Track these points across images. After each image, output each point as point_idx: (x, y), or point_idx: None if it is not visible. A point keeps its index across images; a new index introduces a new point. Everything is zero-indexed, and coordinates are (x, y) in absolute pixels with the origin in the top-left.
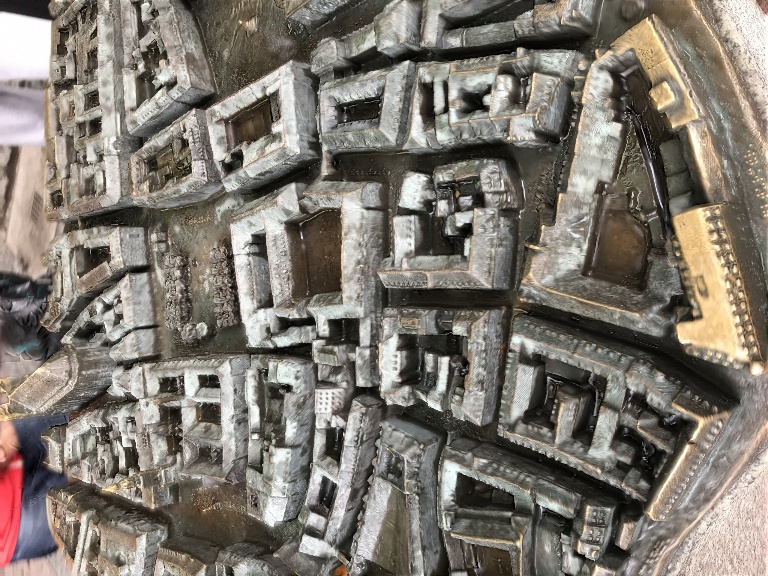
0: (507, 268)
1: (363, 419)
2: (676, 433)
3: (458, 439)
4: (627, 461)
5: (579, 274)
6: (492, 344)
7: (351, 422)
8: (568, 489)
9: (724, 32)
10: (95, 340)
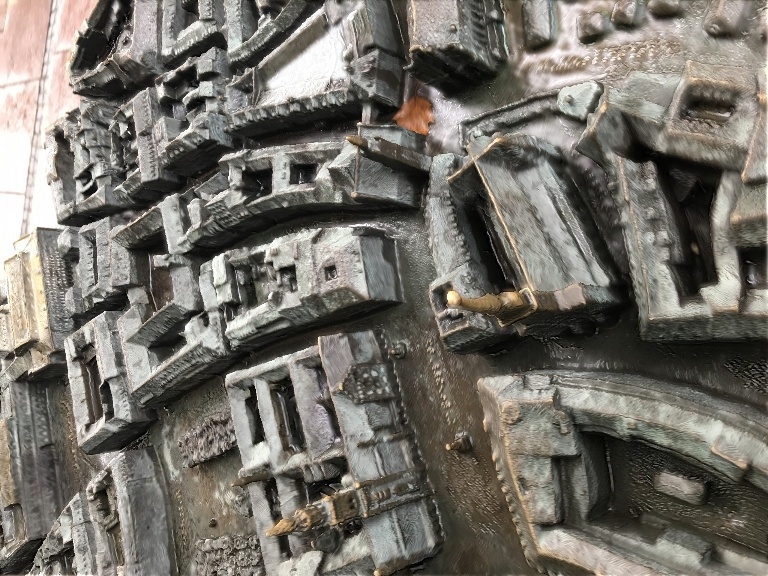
0: None
1: None
2: None
3: None
4: None
5: None
6: None
7: None
8: None
9: None
10: None
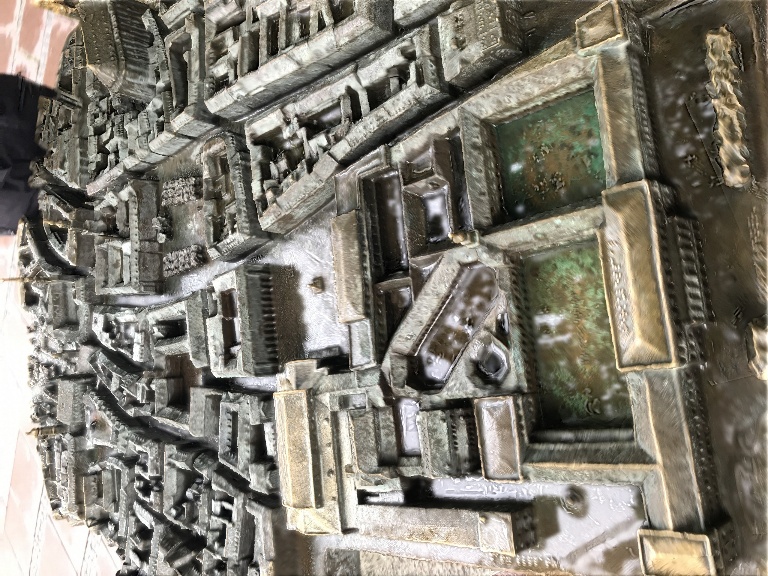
0: None
1: None
2: None
3: None
4: None
5: None
6: None
7: None
8: None
9: None
10: (151, 72)
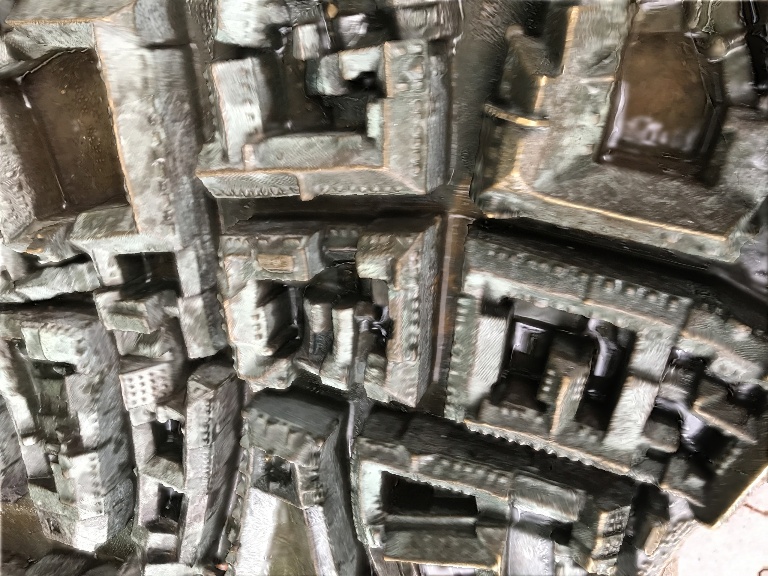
0: (441, 150)
1: (211, 407)
2: (755, 410)
3: (371, 417)
4: (668, 451)
5: (591, 161)
6: (425, 282)
7: (193, 416)
8: (564, 486)
9: None
10: None
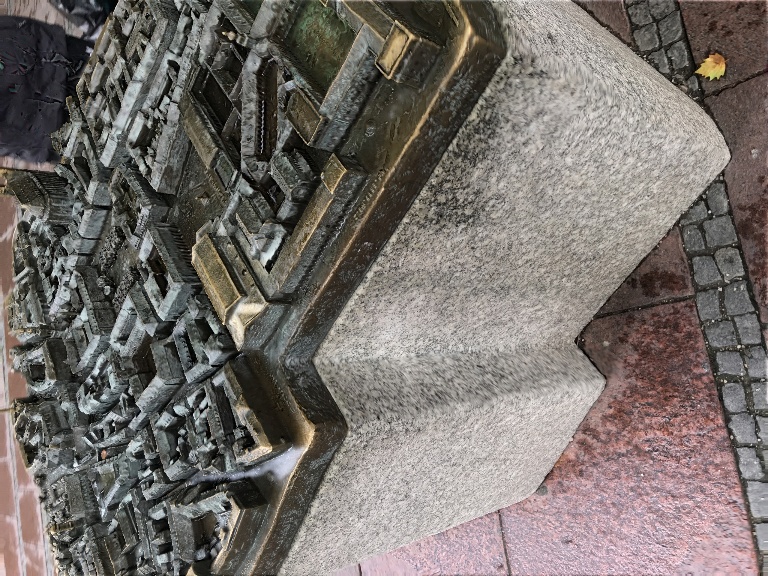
0: None
1: None
2: None
3: None
4: None
5: (190, 519)
6: None
7: None
8: None
9: (312, 504)
10: (70, 197)
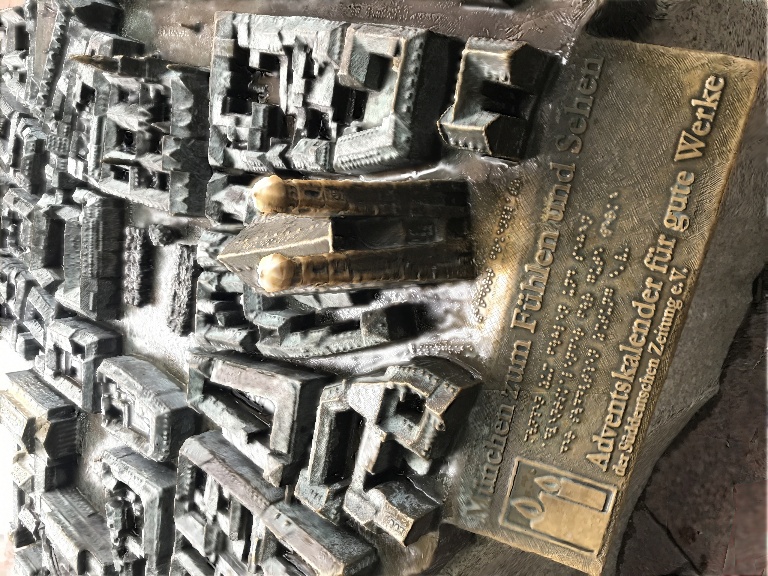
0: None
1: None
2: None
3: None
4: None
5: None
6: None
7: None
8: None
9: None
10: None
